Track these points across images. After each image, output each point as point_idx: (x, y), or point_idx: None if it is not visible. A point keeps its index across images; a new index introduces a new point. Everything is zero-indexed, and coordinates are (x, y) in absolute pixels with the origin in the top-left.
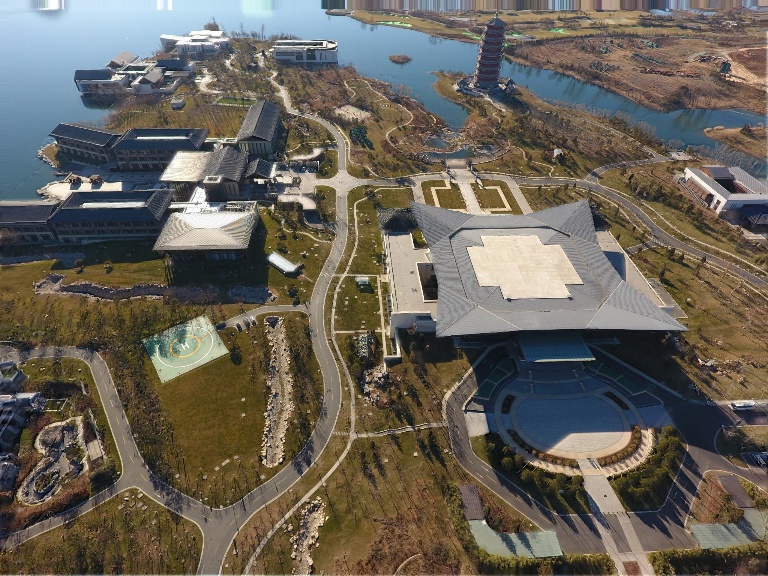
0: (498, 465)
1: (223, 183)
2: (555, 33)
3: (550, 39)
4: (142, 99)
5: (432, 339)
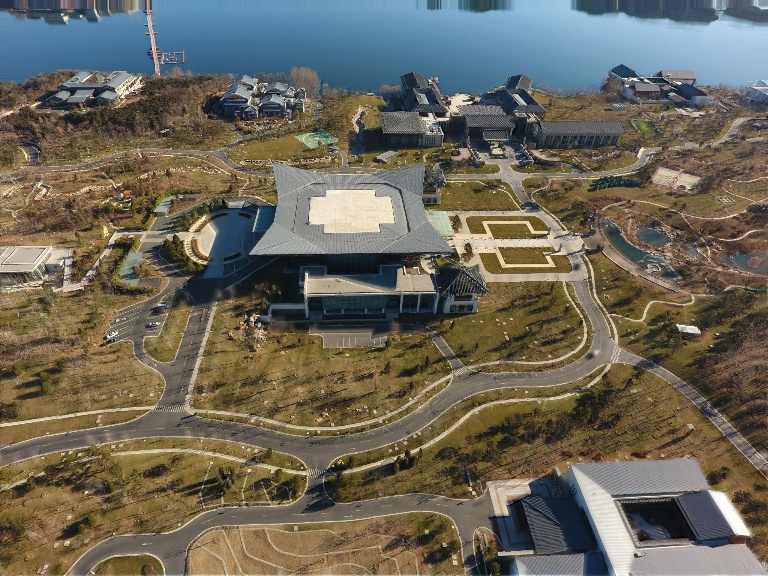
0: None
1: None
2: None
3: None
4: None
5: None
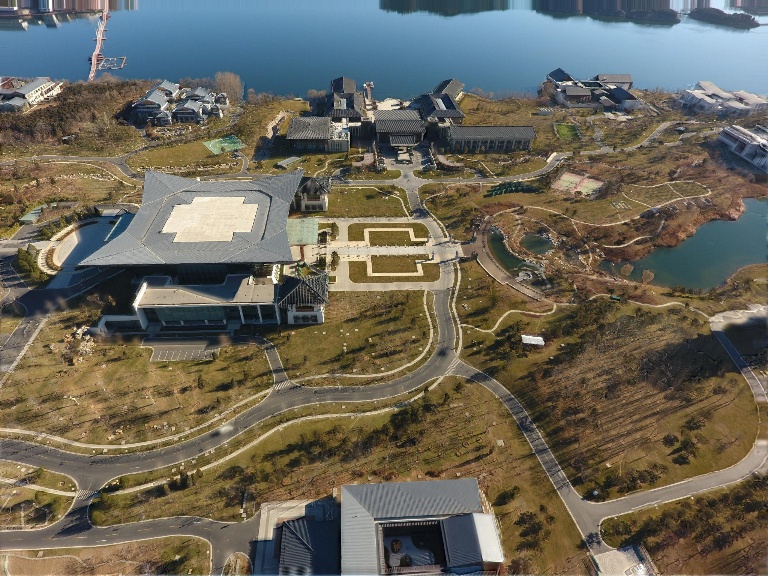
0: None
1: None
2: None
3: None
4: None
5: None
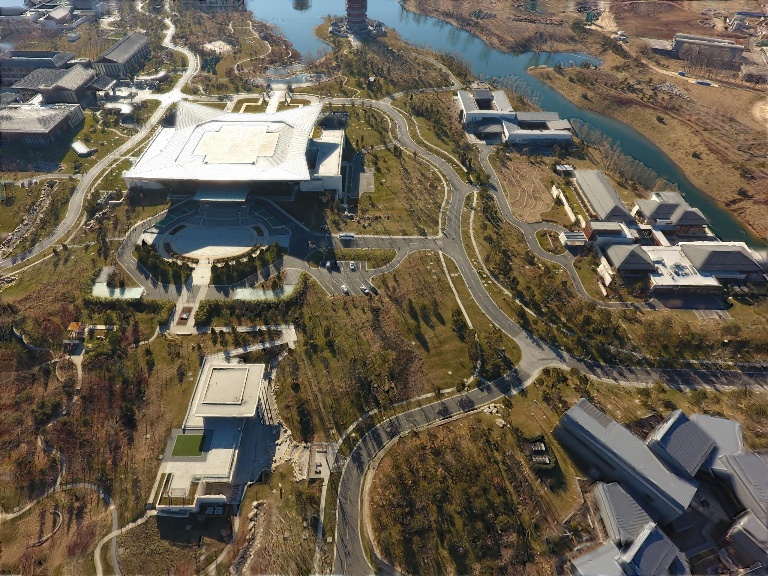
0: None
1: (61, 91)
2: None
3: None
4: (45, 33)
5: (153, 193)
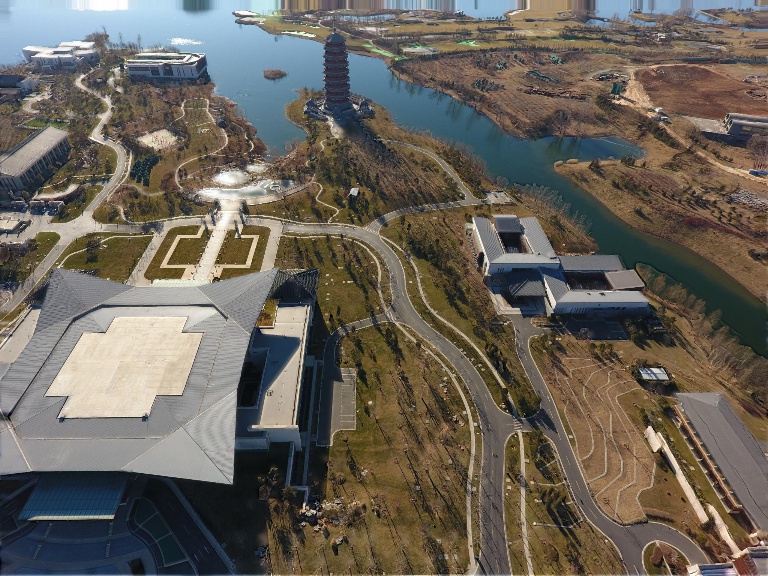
0: None
1: None
2: (463, 46)
3: (448, 53)
4: None
5: None
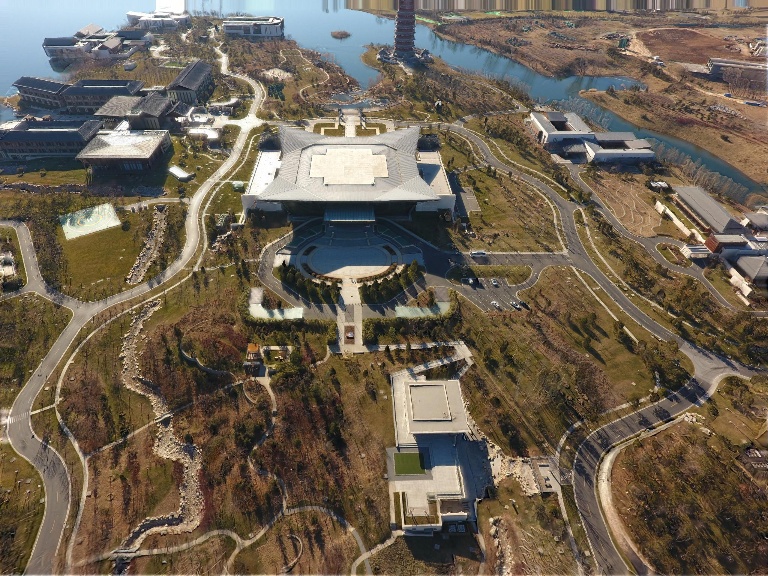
0: (285, 280)
1: (145, 118)
2: (490, 15)
3: (481, 19)
4: (100, 62)
5: (272, 215)
